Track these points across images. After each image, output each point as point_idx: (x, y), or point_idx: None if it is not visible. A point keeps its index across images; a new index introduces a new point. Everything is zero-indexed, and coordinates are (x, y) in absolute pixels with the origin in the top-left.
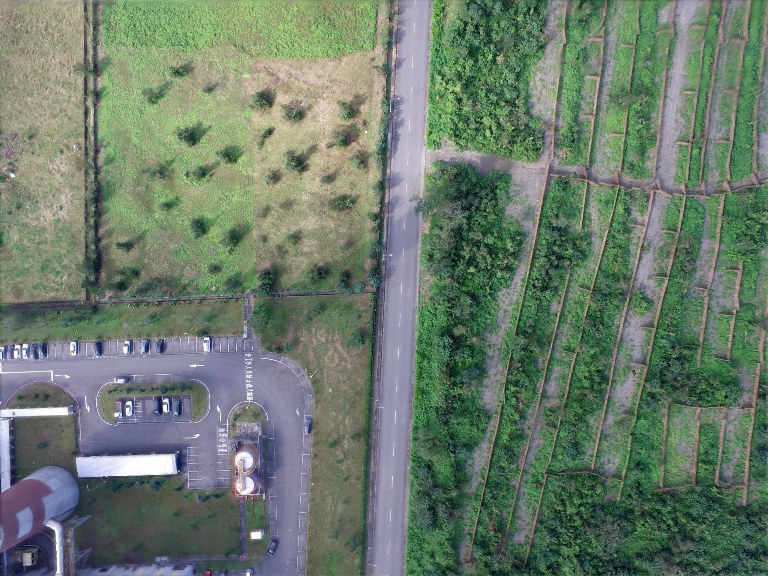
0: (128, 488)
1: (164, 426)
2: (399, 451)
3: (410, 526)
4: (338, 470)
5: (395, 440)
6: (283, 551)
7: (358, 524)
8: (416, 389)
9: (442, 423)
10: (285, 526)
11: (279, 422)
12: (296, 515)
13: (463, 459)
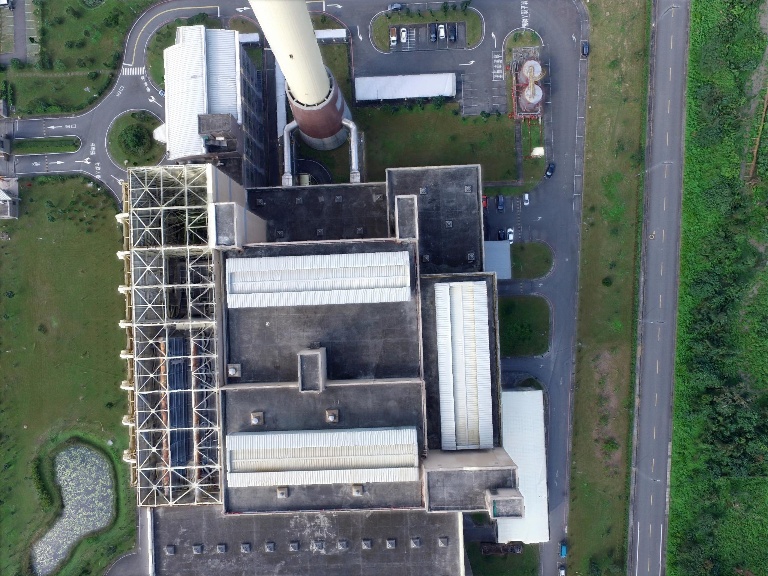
0: (407, 108)
1: (438, 54)
2: (676, 75)
3: (689, 147)
4: (616, 93)
5: (671, 65)
6: (559, 175)
7: (636, 146)
8: (694, 12)
9: (725, 39)
10: (561, 150)
11: (555, 48)
12: (573, 139)
13: (743, 78)
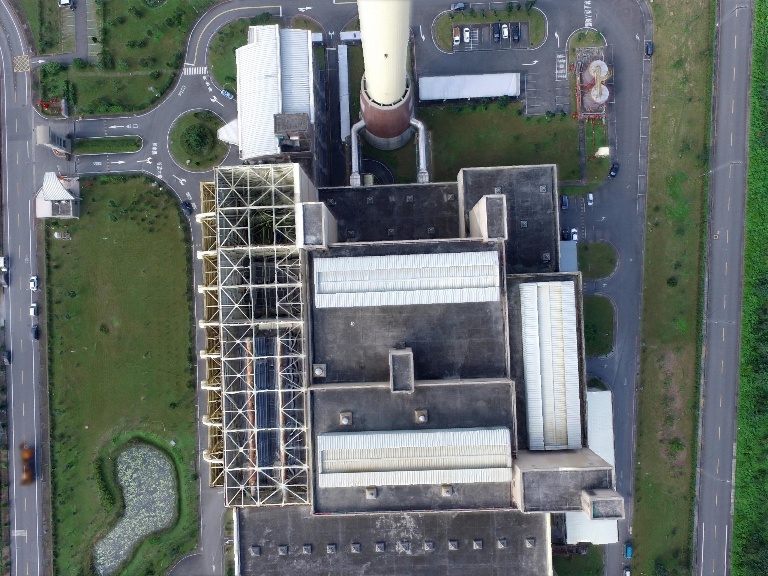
0: (471, 108)
1: (501, 53)
2: (740, 75)
3: (753, 147)
4: (680, 92)
5: (735, 65)
6: (623, 175)
7: (701, 146)
8: (758, 12)
9: None
10: (625, 150)
11: (618, 47)
12: (636, 139)
13: None
